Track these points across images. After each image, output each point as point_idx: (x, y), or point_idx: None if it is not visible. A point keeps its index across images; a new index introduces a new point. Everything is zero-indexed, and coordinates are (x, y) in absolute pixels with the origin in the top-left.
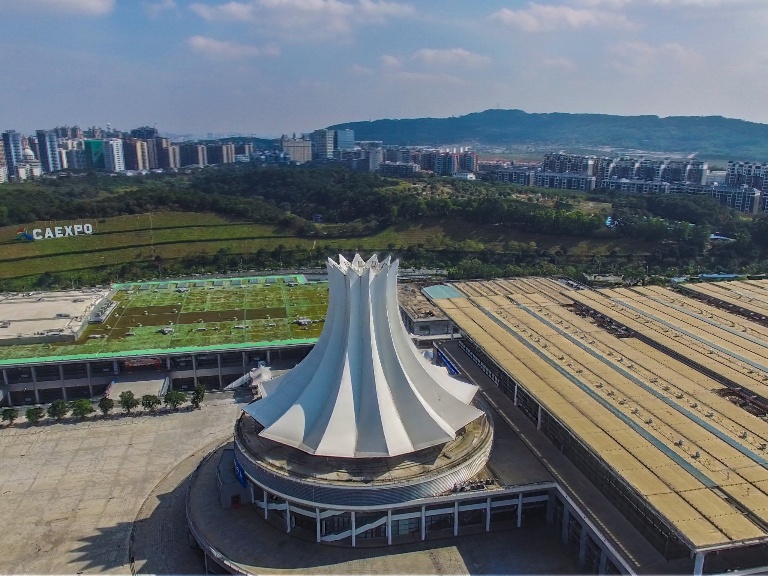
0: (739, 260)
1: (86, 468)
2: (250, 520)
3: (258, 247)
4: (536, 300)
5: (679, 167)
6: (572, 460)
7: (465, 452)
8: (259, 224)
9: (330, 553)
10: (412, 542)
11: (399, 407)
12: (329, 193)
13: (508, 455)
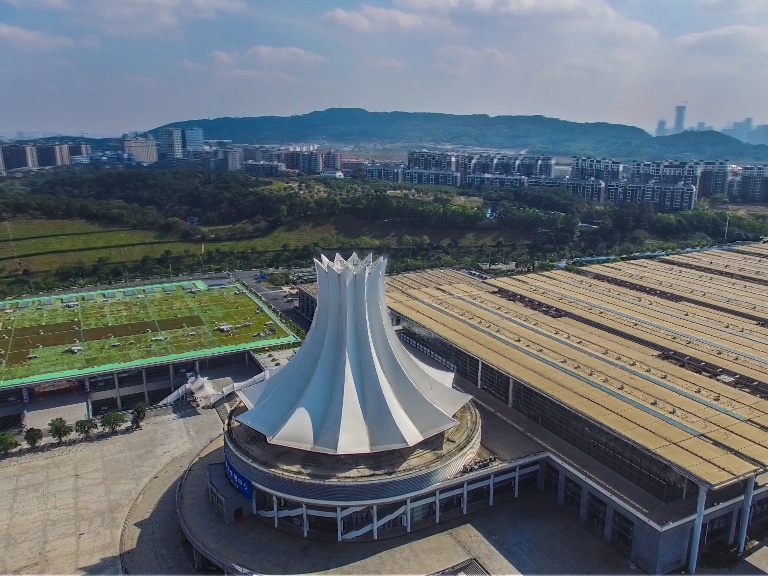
0: (604, 244)
1: (35, 507)
2: (260, 531)
3: (141, 254)
4: (465, 289)
5: (532, 162)
6: (552, 431)
7: (466, 435)
8: (137, 230)
9: (356, 549)
10: (428, 526)
11: (400, 399)
12: (203, 195)
13: (495, 433)
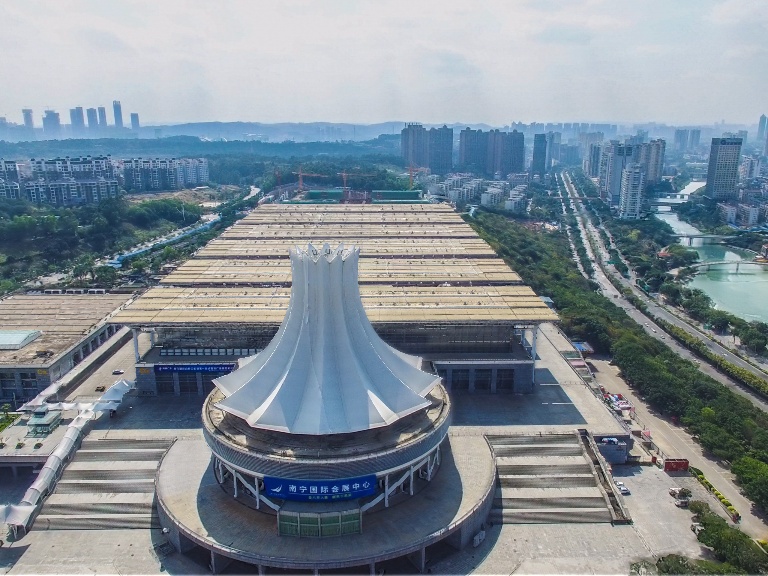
0: (110, 241)
1: None
2: (387, 516)
3: None
4: (173, 291)
5: None
6: (410, 352)
7: None
8: None
9: (446, 475)
10: None
11: None
12: None
13: None
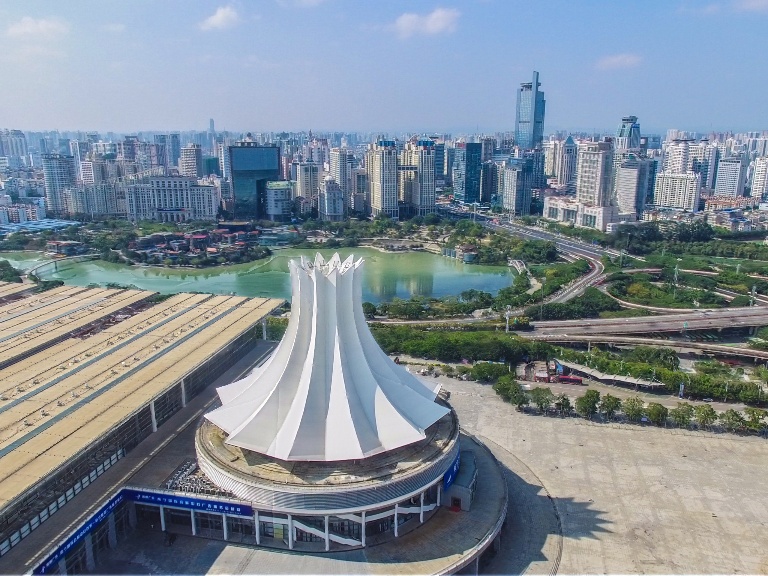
0: None
1: None
2: None
3: None
4: None
5: None
6: None
7: None
8: None
9: None
10: None
11: None
12: None
13: None
